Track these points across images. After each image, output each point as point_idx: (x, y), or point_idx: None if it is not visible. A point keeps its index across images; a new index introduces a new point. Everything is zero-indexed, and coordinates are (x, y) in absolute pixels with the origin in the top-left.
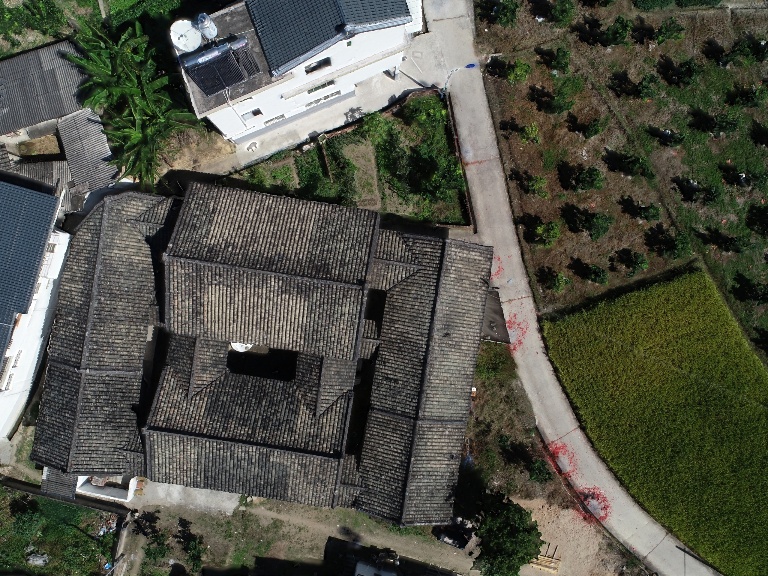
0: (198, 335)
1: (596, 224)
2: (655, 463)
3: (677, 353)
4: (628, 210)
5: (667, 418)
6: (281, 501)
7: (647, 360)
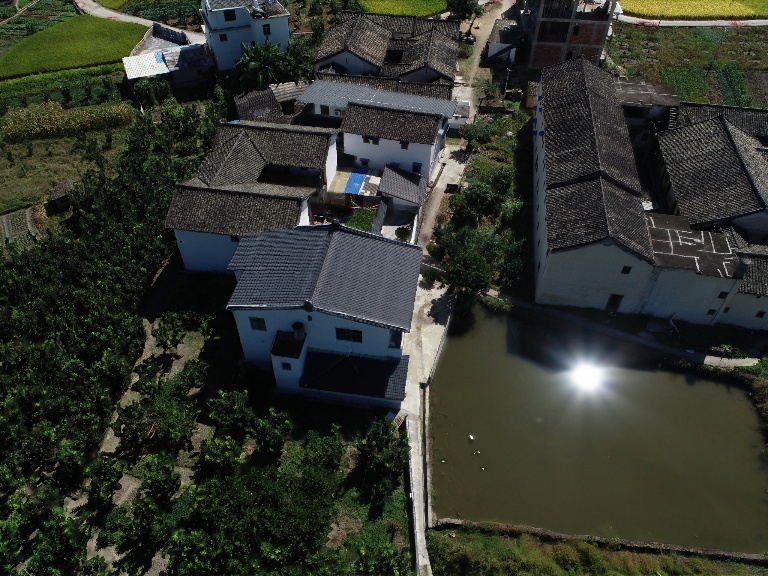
0: (382, 61)
1: (337, 8)
2: (432, 5)
3: (388, 1)
4: (331, 13)
5: (414, 3)
6: (464, 77)
7: (391, 6)
